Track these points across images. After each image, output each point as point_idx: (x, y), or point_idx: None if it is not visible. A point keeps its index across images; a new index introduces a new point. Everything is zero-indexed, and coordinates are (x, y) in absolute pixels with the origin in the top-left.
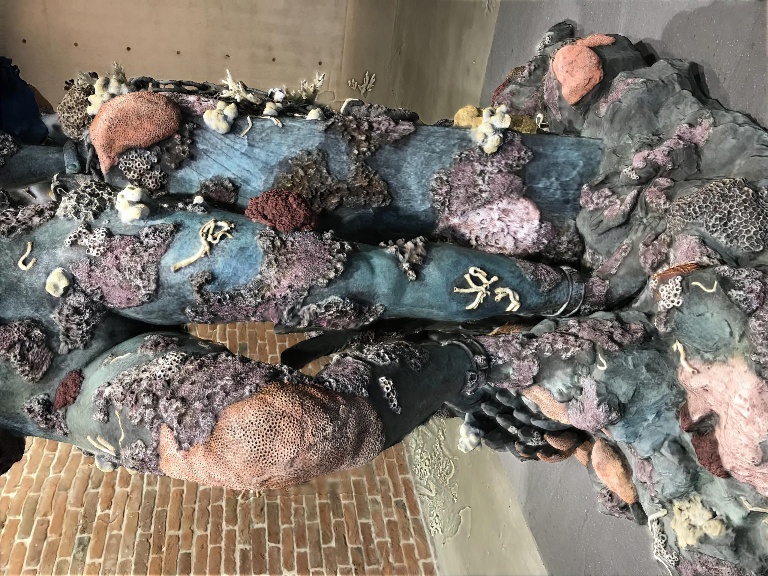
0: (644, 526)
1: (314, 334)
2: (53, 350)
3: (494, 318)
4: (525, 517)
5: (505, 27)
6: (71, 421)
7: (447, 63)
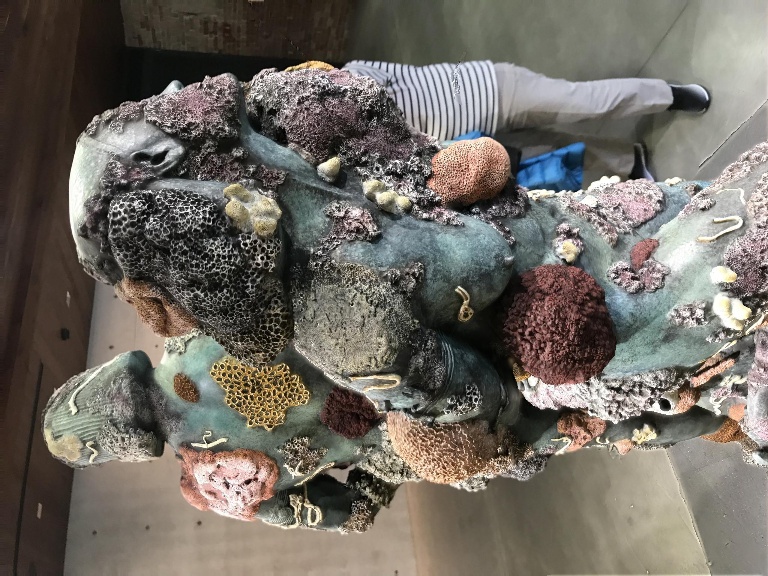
0: None
1: None
2: None
3: None
4: None
5: None
6: (666, 256)
7: (598, 543)
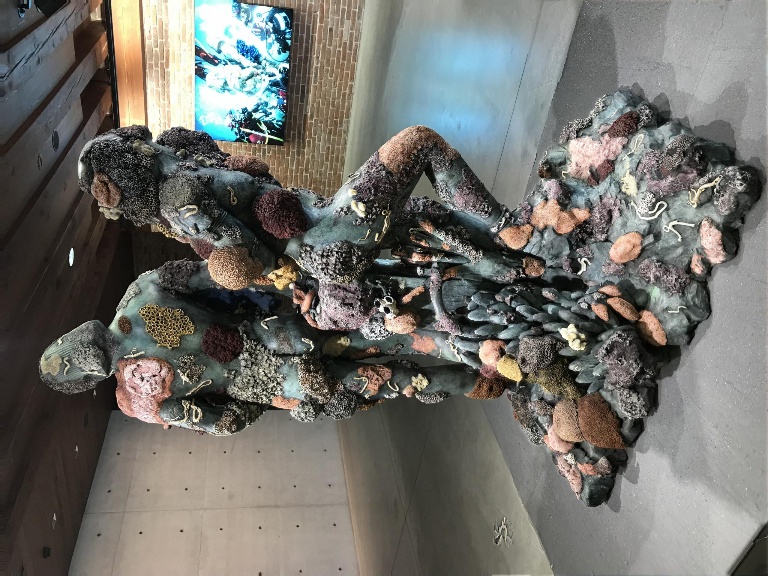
0: (713, 299)
1: (434, 276)
2: (324, 198)
3: (517, 253)
4: (762, 520)
5: (510, 451)
6: None
7: None
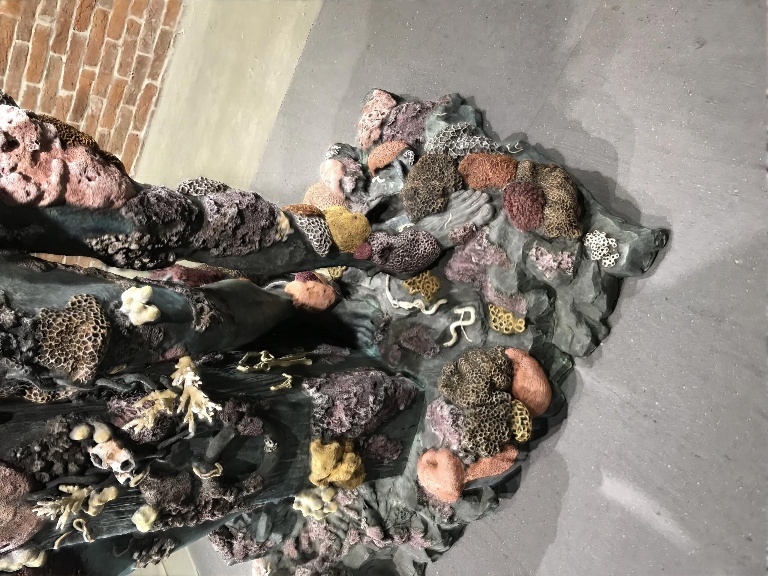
0: None
1: None
2: None
3: None
4: None
5: None
6: None
7: None
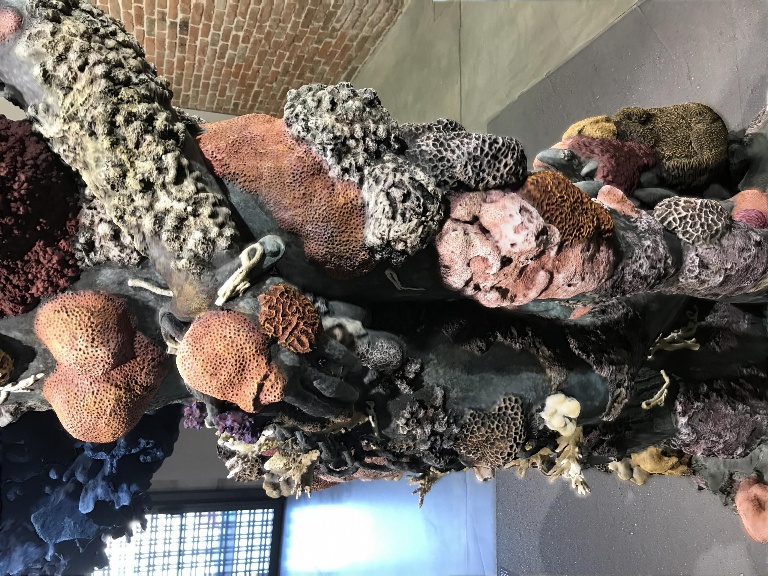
0: None
1: None
2: None
3: None
4: None
5: None
6: None
7: None
